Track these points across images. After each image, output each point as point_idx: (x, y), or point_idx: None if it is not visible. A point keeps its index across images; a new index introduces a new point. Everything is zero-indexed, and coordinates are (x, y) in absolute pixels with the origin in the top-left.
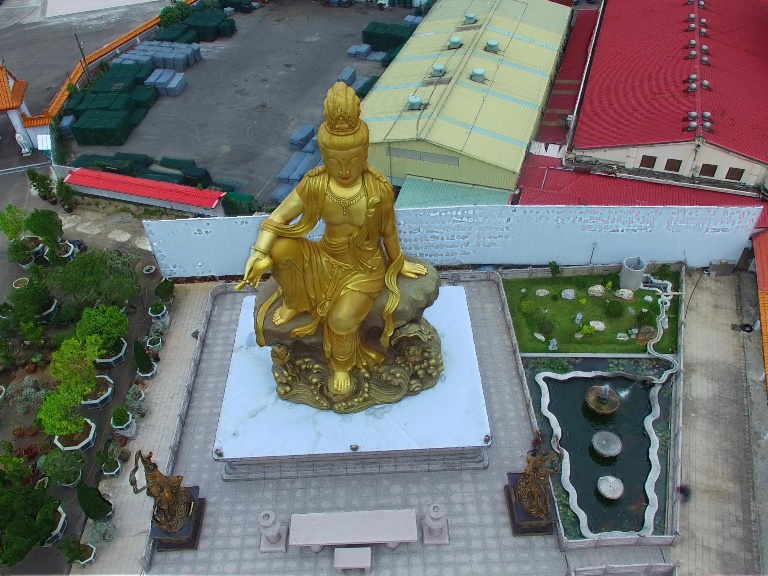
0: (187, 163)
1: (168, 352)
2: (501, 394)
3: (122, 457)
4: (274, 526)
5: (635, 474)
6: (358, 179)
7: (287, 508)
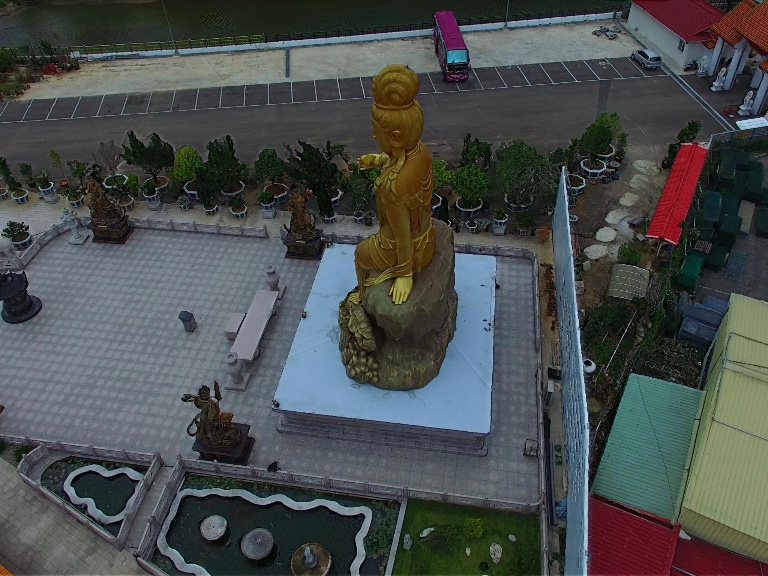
0: (765, 227)
1: (466, 236)
2: (355, 465)
3: (367, 220)
4: (268, 276)
5: (223, 568)
6: (393, 160)
7: (296, 299)
